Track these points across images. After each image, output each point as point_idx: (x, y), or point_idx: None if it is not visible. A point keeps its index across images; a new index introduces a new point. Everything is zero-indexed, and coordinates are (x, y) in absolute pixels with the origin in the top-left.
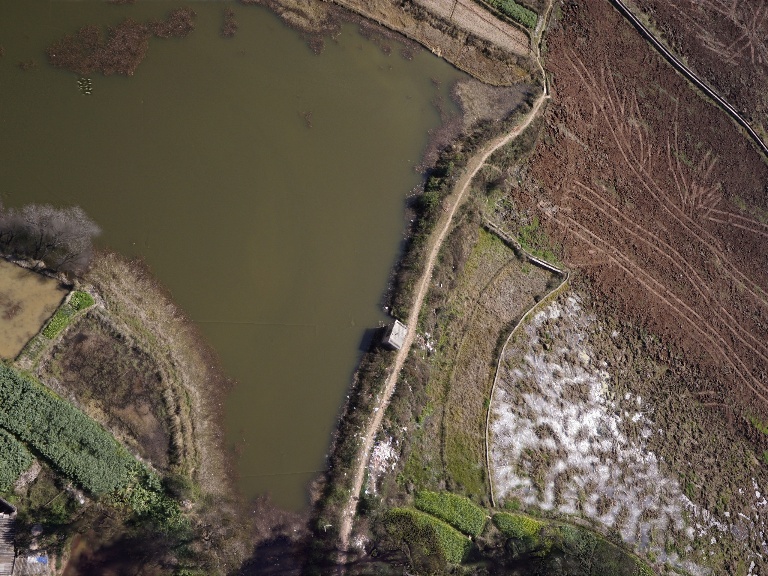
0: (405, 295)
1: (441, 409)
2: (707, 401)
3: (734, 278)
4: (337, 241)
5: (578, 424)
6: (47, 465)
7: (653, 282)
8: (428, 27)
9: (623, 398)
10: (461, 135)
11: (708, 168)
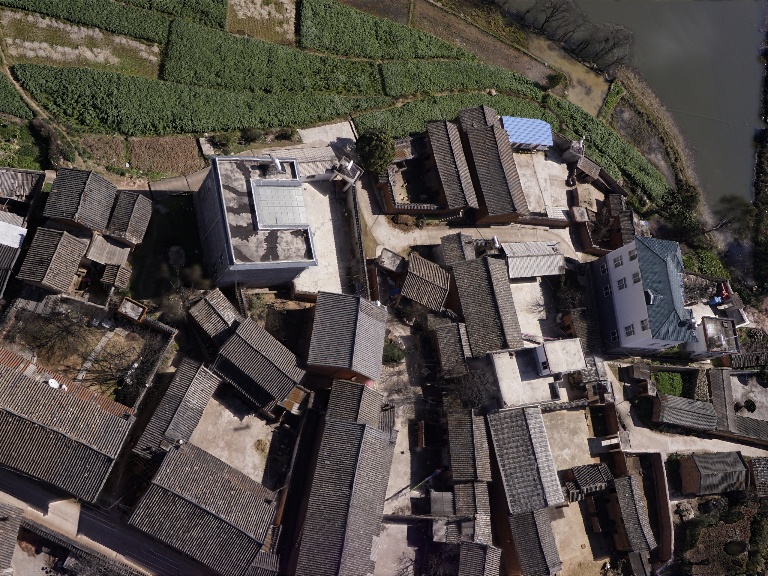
0: None
1: None
2: None
3: None
4: (729, 72)
5: None
6: (626, 179)
7: None
8: None
9: None
10: None
11: None
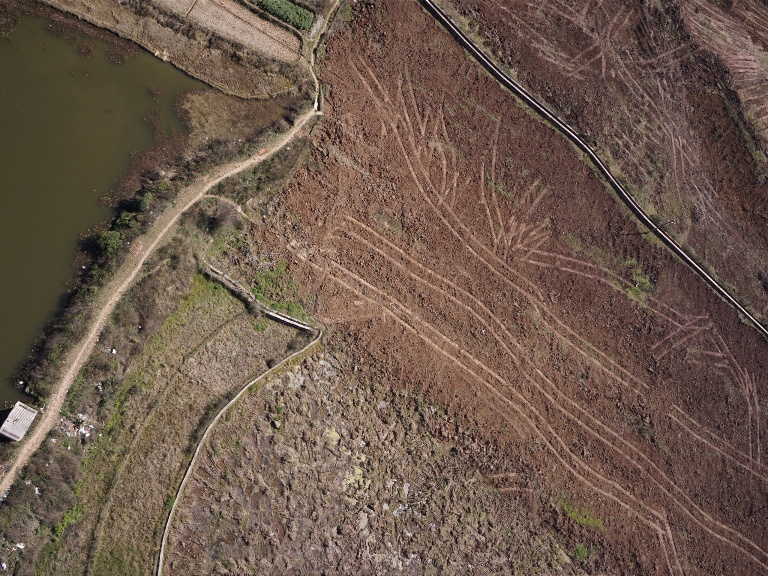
0: (45, 367)
1: (96, 513)
2: (504, 486)
3: (557, 333)
4: None
5: (310, 523)
6: None
7: (443, 340)
8: (154, 25)
9: (383, 486)
10: (180, 159)
11: (534, 201)
